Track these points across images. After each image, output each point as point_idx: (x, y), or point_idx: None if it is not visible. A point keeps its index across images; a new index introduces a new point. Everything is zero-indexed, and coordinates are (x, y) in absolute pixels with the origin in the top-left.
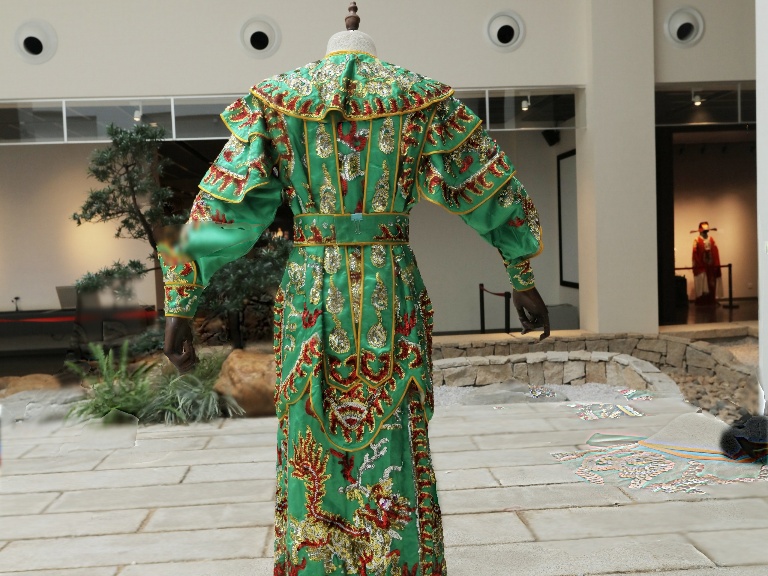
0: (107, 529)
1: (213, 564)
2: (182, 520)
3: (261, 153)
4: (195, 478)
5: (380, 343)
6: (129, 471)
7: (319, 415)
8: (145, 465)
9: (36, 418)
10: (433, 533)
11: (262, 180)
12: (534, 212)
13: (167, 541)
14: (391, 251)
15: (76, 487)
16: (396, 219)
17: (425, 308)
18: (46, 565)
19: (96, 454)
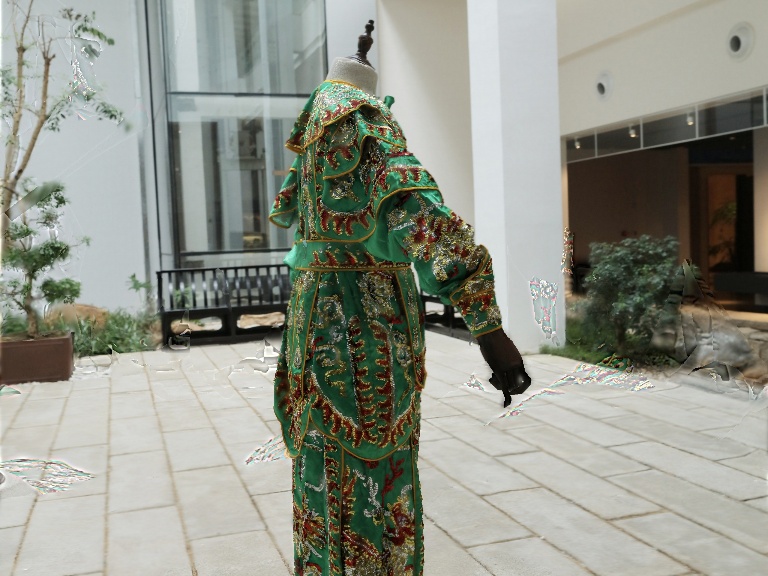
0: (598, 508)
1: (572, 569)
2: (654, 529)
3: (286, 187)
4: (763, 502)
5: (299, 364)
6: (734, 473)
7: (278, 416)
8: (759, 473)
9: (765, 400)
10: (351, 570)
11: (275, 211)
12: (457, 237)
13: (600, 537)
14: (319, 278)
15: (668, 469)
16: (326, 246)
17: (352, 339)
18: (511, 511)
19: (740, 448)
